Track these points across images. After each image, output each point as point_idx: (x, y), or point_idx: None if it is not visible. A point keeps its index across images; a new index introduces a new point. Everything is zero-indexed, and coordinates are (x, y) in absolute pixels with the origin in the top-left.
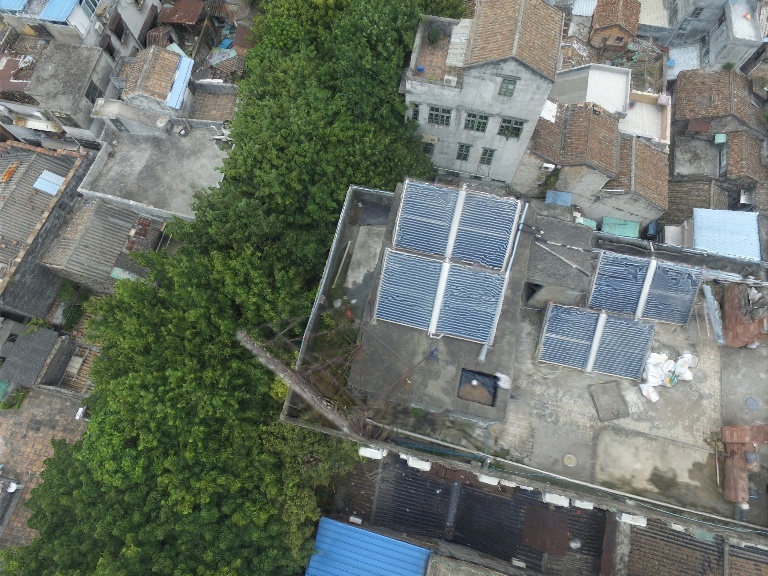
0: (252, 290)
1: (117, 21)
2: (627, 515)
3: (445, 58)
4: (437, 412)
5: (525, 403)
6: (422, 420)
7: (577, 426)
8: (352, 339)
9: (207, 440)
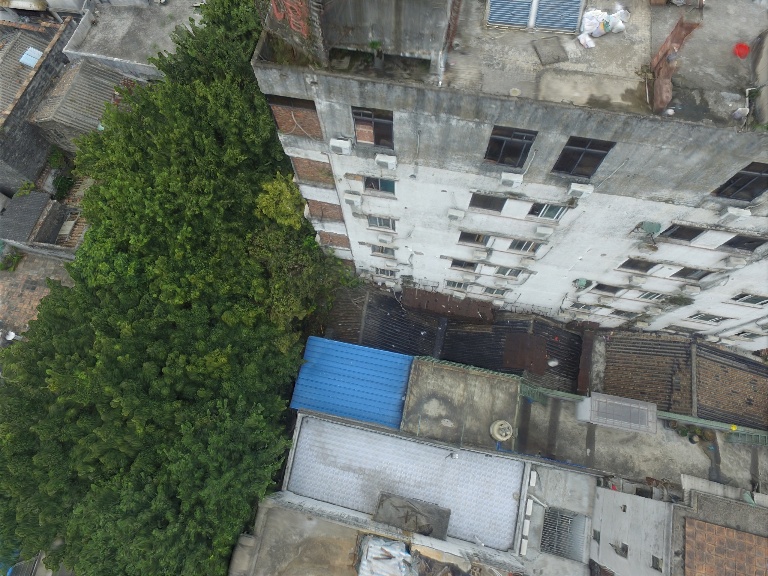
0: (233, 112)
1: None
2: (576, 184)
3: None
4: (393, 49)
5: (475, 57)
6: (382, 73)
7: (522, 70)
8: None
9: (195, 250)
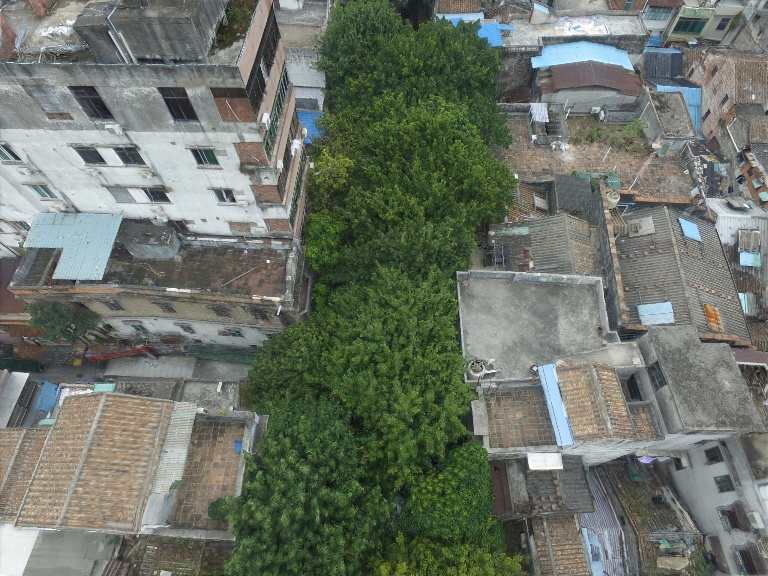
0: None
1: (756, 566)
2: None
3: (208, 484)
4: None
5: None
6: None
7: None
8: (238, 21)
9: None
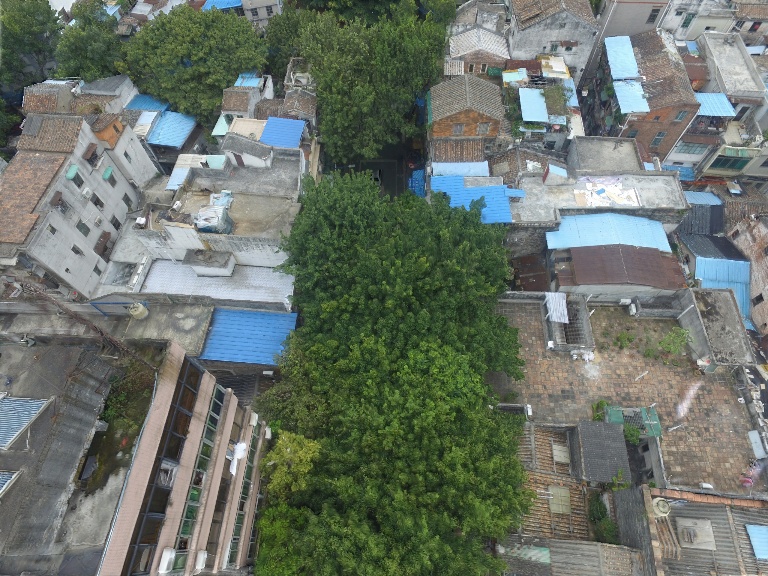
0: (350, 541)
1: None
2: None
3: None
4: None
5: None
6: None
7: None
8: None
9: None
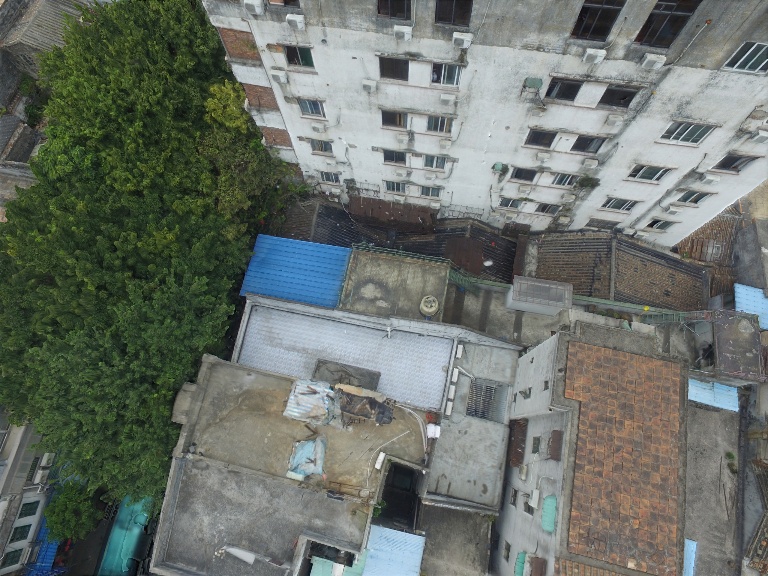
0: (184, 24)
1: None
2: (458, 33)
3: None
4: None
5: None
6: None
7: None
8: None
9: (149, 147)
